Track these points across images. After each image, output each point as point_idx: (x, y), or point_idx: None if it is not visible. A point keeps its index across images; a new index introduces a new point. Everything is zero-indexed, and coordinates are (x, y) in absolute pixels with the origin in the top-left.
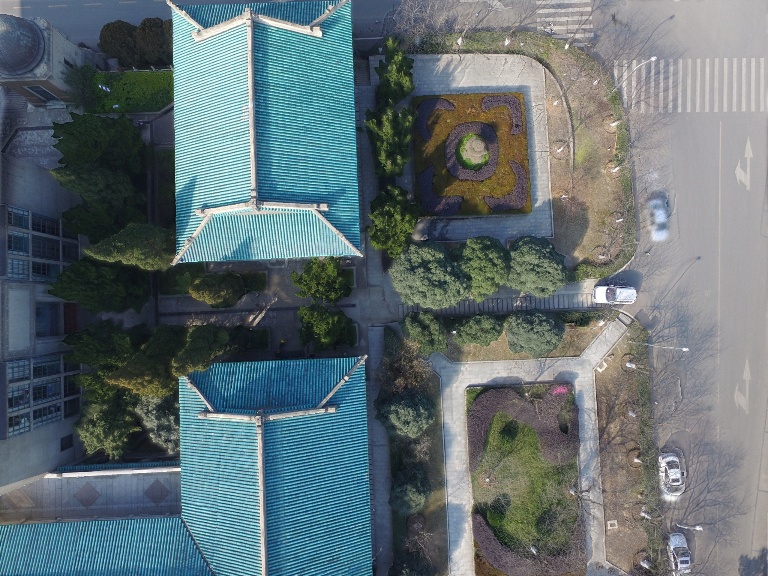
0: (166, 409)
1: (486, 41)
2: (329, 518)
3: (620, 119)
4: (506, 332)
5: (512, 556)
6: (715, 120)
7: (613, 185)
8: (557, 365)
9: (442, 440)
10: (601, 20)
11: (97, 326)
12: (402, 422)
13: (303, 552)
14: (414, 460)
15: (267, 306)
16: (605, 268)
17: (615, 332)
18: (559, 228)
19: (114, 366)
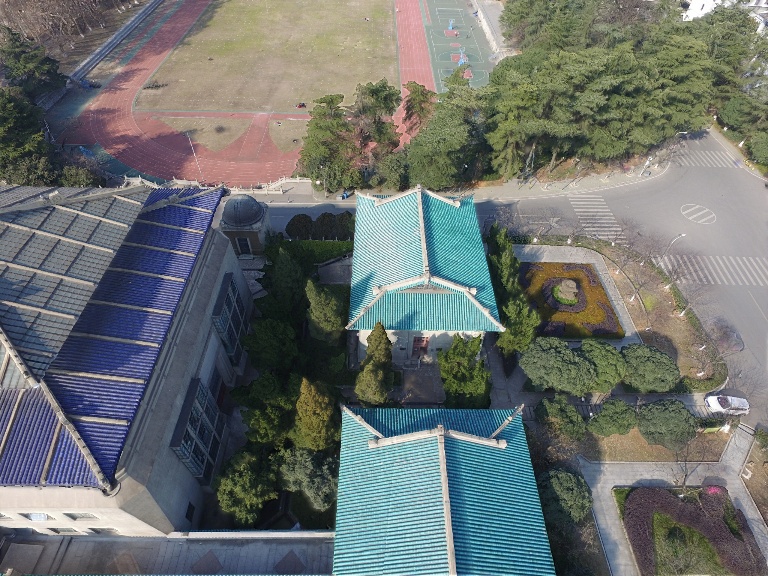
0: None
1: None
2: (515, 569)
3: (671, 282)
4: (639, 423)
5: None
6: (744, 290)
7: (684, 325)
8: (699, 470)
9: (602, 549)
10: (630, 235)
11: None
12: (564, 489)
13: None
14: (582, 550)
15: (402, 400)
16: (707, 382)
17: (743, 440)
18: None
19: None
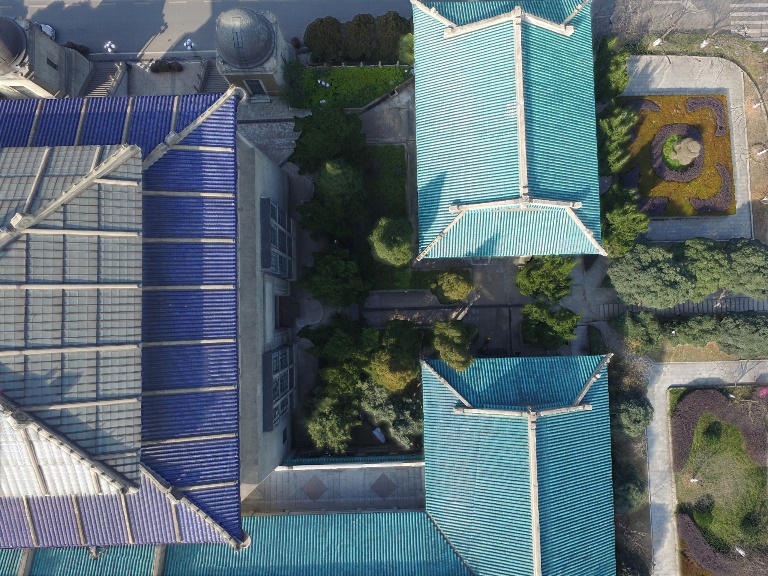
0: (397, 404)
1: (683, 43)
2: (583, 515)
3: None
4: None
5: (721, 557)
6: None
7: None
8: (758, 367)
9: None
10: None
11: (337, 320)
12: (632, 421)
13: (565, 548)
14: (632, 459)
15: (470, 303)
16: None
17: None
18: (758, 231)
19: (352, 360)
